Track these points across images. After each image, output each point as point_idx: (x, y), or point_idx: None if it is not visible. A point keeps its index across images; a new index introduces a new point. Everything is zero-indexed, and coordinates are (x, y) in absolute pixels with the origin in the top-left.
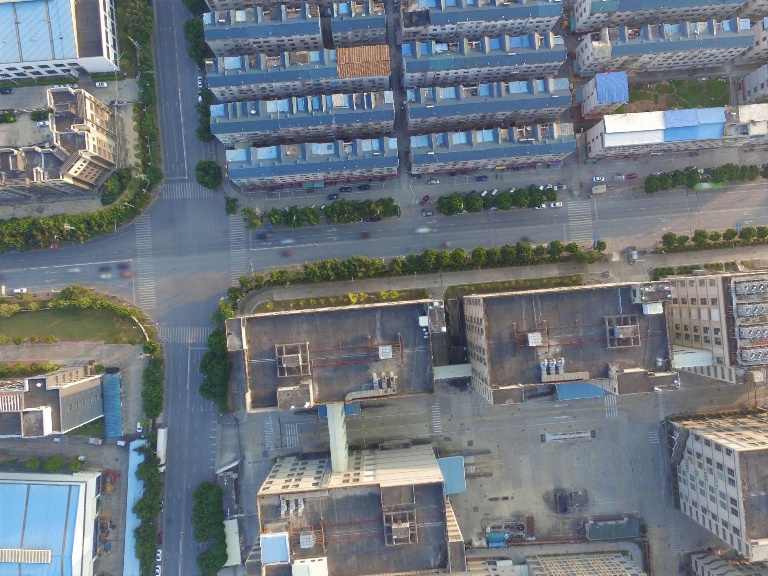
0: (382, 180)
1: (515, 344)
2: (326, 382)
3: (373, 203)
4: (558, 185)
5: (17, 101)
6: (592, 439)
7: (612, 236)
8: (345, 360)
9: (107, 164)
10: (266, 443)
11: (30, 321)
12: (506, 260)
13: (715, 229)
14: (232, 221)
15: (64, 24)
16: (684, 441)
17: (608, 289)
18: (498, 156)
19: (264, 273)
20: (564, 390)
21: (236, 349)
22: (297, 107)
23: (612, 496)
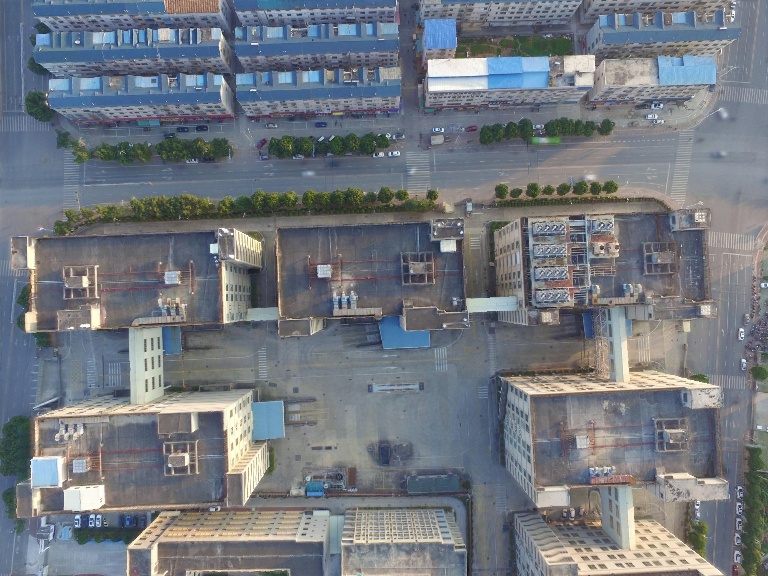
0: (220, 122)
1: (308, 277)
2: (115, 307)
3: (201, 141)
4: (397, 134)
5: None
6: (420, 391)
7: (449, 188)
8: (135, 285)
9: None
10: (88, 381)
11: None
12: (336, 205)
13: (554, 185)
14: (67, 156)
15: None
16: (505, 394)
17: (407, 226)
18: (323, 97)
19: (96, 209)
20: (389, 338)
21: (20, 268)
22: (123, 39)
23: (438, 450)
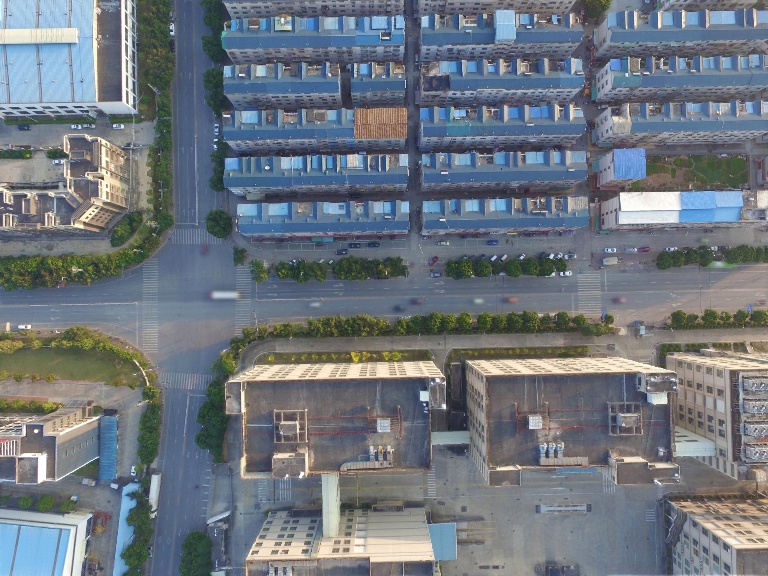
0: (392, 238)
1: (515, 424)
2: (322, 450)
3: (381, 264)
4: (569, 254)
5: (34, 138)
6: (588, 513)
7: (620, 309)
8: (343, 429)
9: (119, 207)
10: (259, 495)
11: (32, 357)
12: (512, 328)
13: (726, 308)
14: (239, 270)
15: (85, 68)
16: (681, 524)
17: (613, 374)
18: (510, 226)
19: (268, 324)
20: None
21: None
22: (311, 165)
23: (604, 572)
